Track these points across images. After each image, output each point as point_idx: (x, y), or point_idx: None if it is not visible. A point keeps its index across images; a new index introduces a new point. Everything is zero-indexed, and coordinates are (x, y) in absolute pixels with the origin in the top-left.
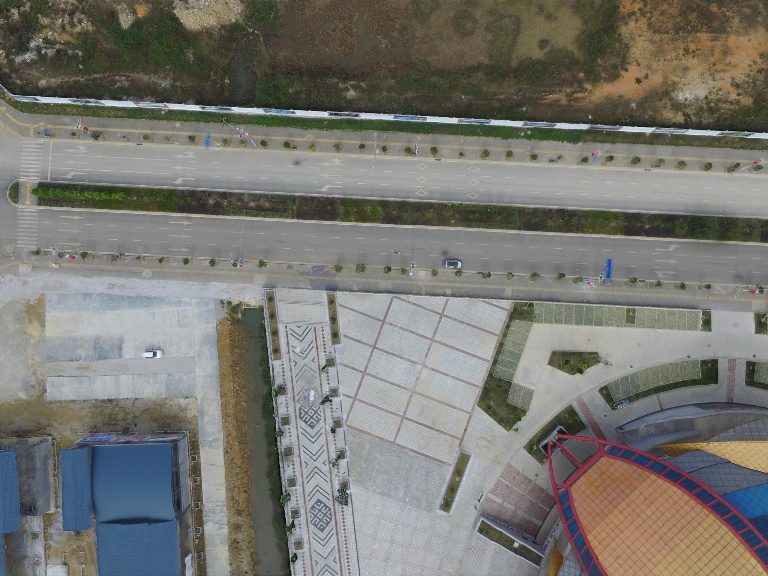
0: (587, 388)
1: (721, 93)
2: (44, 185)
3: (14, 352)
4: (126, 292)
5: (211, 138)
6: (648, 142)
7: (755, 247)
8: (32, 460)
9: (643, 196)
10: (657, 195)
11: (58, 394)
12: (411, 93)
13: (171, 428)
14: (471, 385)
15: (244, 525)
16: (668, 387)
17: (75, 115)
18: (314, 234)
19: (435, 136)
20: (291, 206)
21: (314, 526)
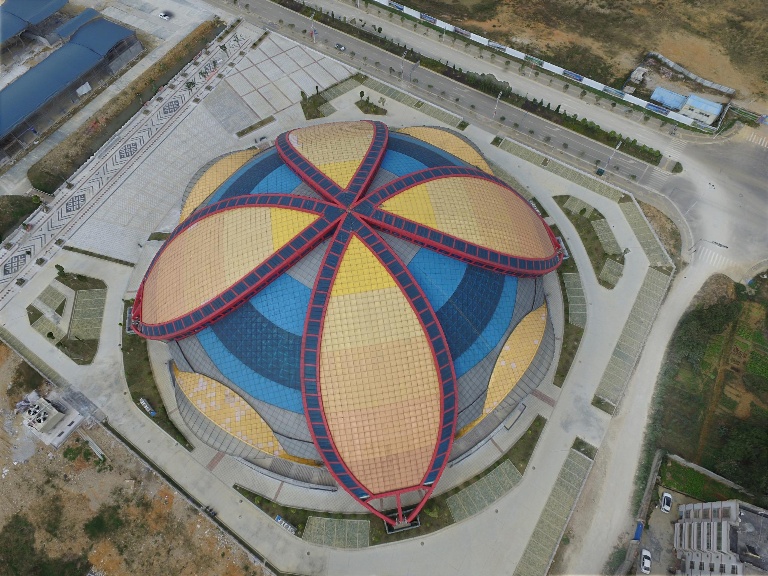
0: None
1: (538, 46)
2: None
3: None
4: None
5: None
6: (483, 48)
7: (517, 110)
8: None
9: (465, 66)
10: (474, 69)
11: (108, 13)
12: None
13: None
14: (305, 93)
15: (129, 95)
16: None
17: None
18: (283, 13)
19: (373, 6)
20: None
21: (163, 110)
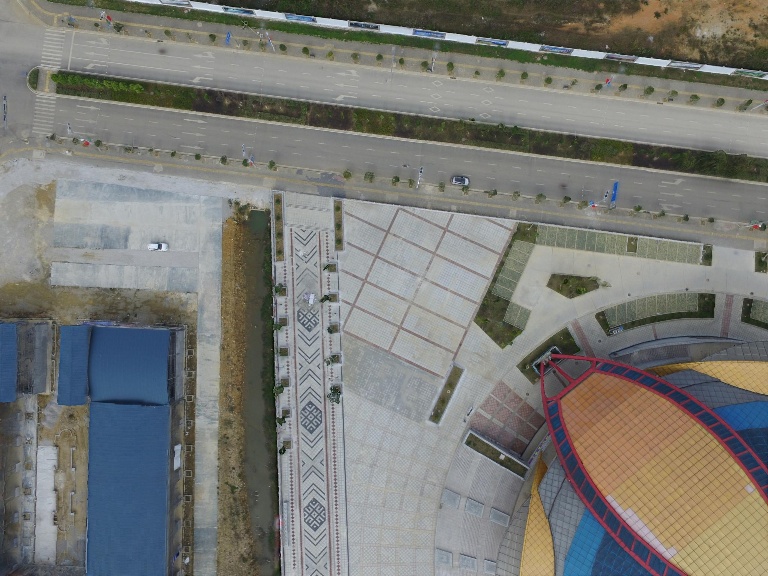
0: (584, 312)
1: (739, 33)
2: (64, 73)
3: (22, 235)
4: (136, 184)
5: (231, 40)
6: (663, 76)
7: (761, 187)
8: (31, 342)
9: (654, 129)
10: (667, 129)
11: (62, 279)
12: (432, 11)
13: (170, 321)
14: (469, 301)
15: (235, 422)
16: (664, 317)
17: (99, 8)
18: (326, 142)
19: (452, 54)
20: (305, 112)
21: (304, 427)
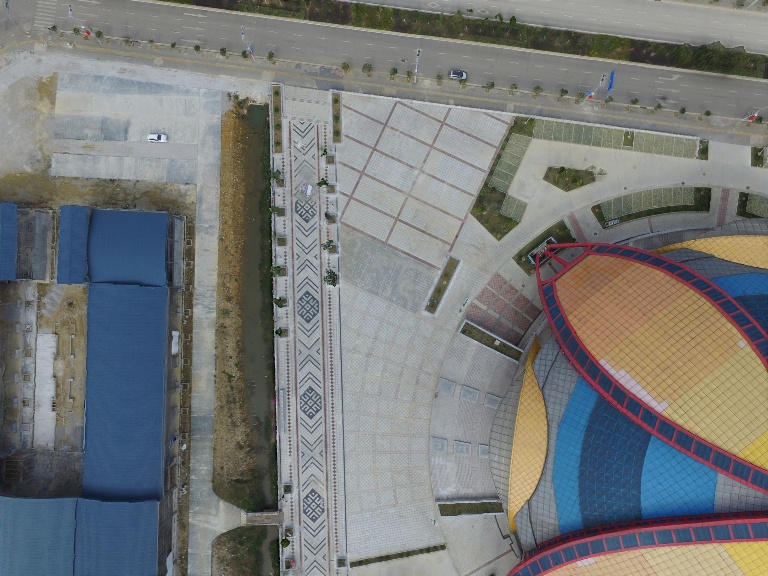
0: (580, 205)
1: None
2: None
3: (23, 126)
4: (136, 77)
5: None
6: None
7: (758, 83)
8: (32, 231)
9: (651, 25)
10: (665, 25)
11: (62, 170)
12: None
13: (169, 212)
14: (466, 193)
15: (232, 312)
16: (660, 209)
17: None
18: (324, 36)
19: None
20: (304, 6)
21: (301, 317)
